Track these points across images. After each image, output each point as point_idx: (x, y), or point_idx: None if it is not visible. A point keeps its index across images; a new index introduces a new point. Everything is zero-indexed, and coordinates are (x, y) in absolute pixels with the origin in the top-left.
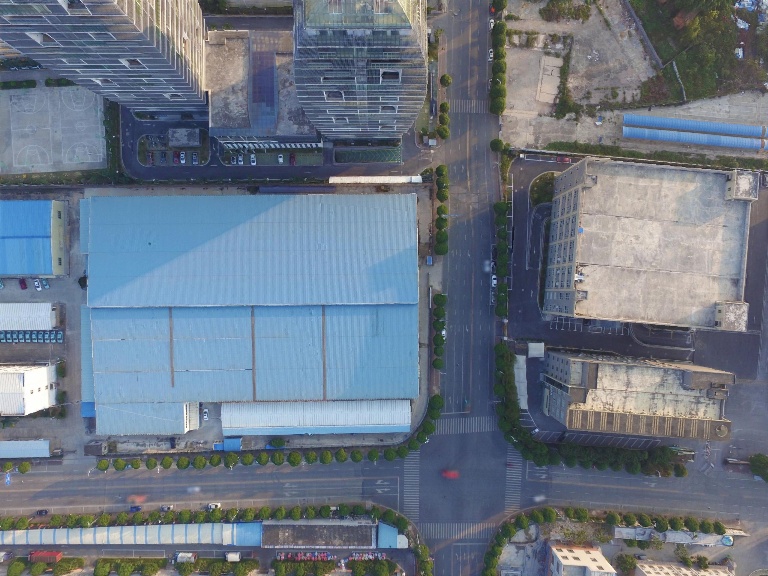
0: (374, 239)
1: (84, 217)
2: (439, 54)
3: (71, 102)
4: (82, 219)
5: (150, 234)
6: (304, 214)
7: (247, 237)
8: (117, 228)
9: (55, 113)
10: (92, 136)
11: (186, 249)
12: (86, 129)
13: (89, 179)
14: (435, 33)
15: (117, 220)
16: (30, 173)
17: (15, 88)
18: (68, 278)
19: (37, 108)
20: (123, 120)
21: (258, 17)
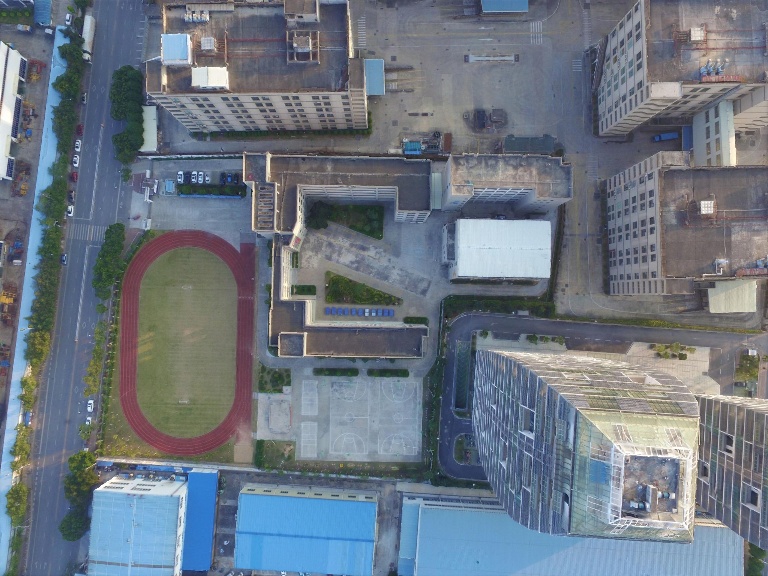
0: (700, 574)
1: (406, 521)
2: (759, 373)
3: (391, 393)
4: (404, 523)
5: (478, 552)
6: (631, 542)
7: (574, 562)
8: (446, 543)
9: (374, 403)
10: (409, 428)
11: (513, 570)
12: (404, 421)
13: (408, 477)
14: (763, 358)
15: (446, 534)
16: (345, 461)
17: (338, 376)
18: (374, 569)
19: (357, 396)
20: (442, 417)
21: (583, 323)
